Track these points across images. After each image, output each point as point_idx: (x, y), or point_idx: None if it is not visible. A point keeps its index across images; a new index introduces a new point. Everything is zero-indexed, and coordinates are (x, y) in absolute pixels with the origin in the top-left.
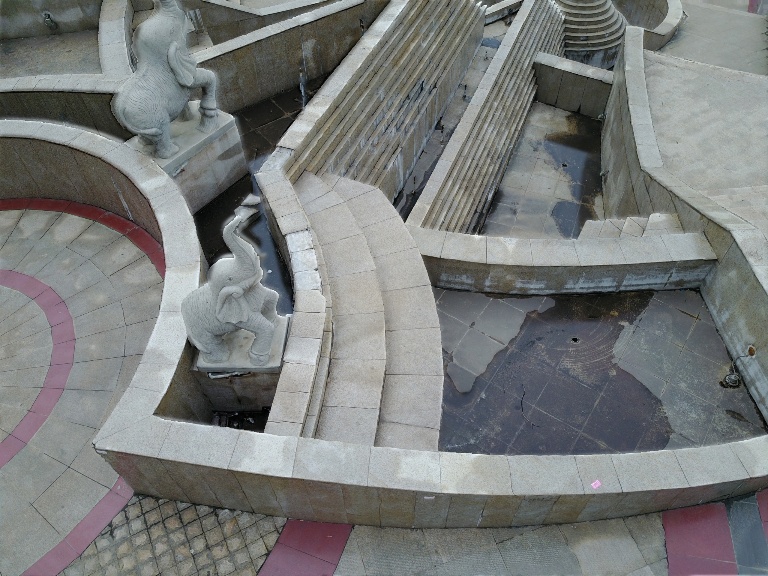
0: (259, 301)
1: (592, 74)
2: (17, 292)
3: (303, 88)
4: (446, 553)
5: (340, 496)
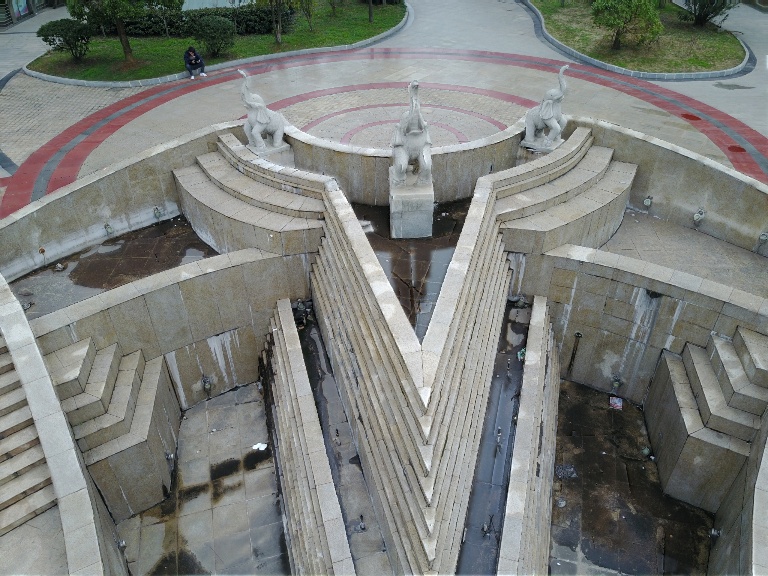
0: None
1: None
2: None
3: (411, 267)
4: None
5: None
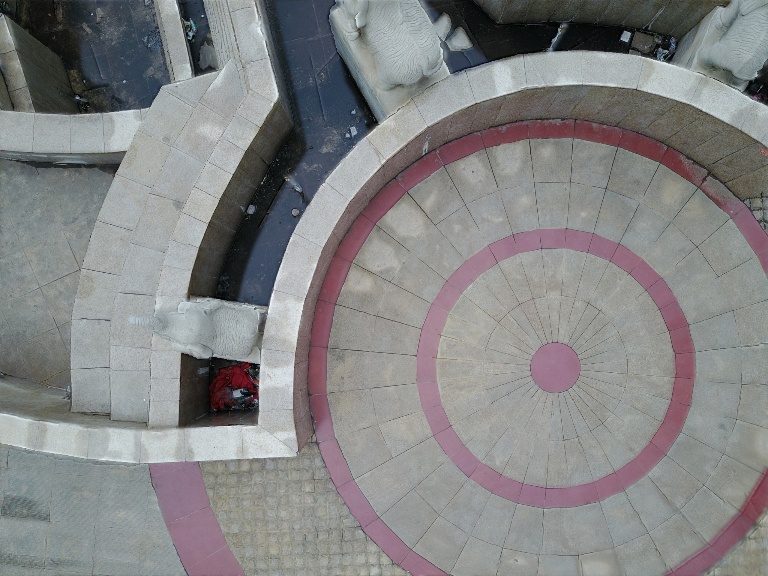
0: None
1: None
2: (481, 277)
3: None
4: None
5: None
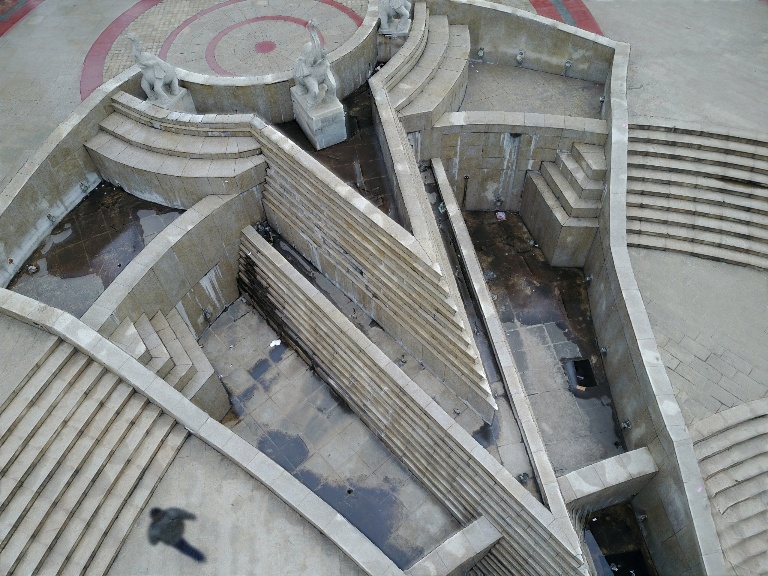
0: None
1: (425, 566)
2: None
3: None
4: None
5: None
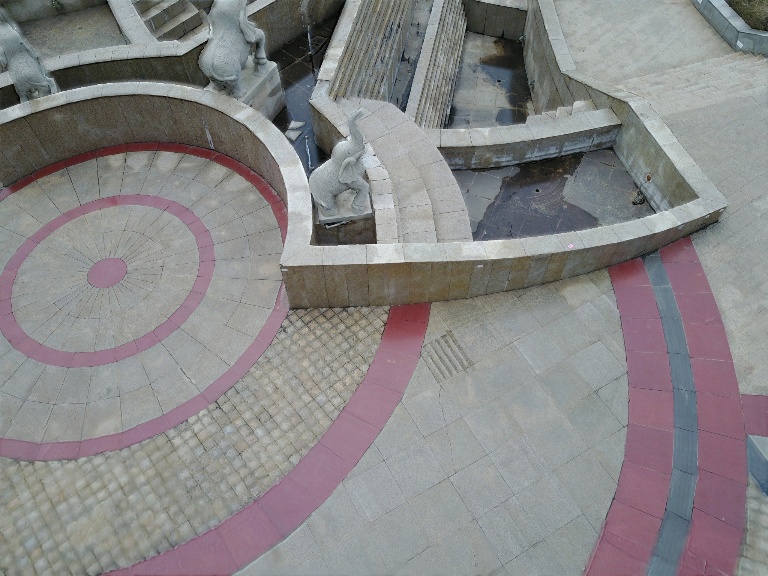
0: (361, 168)
1: (510, 4)
2: (150, 207)
3: None
4: (489, 307)
5: (429, 275)
